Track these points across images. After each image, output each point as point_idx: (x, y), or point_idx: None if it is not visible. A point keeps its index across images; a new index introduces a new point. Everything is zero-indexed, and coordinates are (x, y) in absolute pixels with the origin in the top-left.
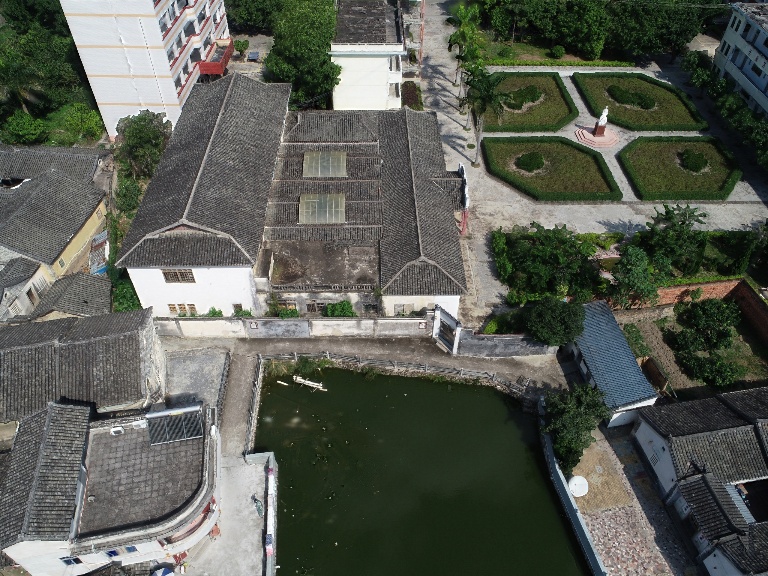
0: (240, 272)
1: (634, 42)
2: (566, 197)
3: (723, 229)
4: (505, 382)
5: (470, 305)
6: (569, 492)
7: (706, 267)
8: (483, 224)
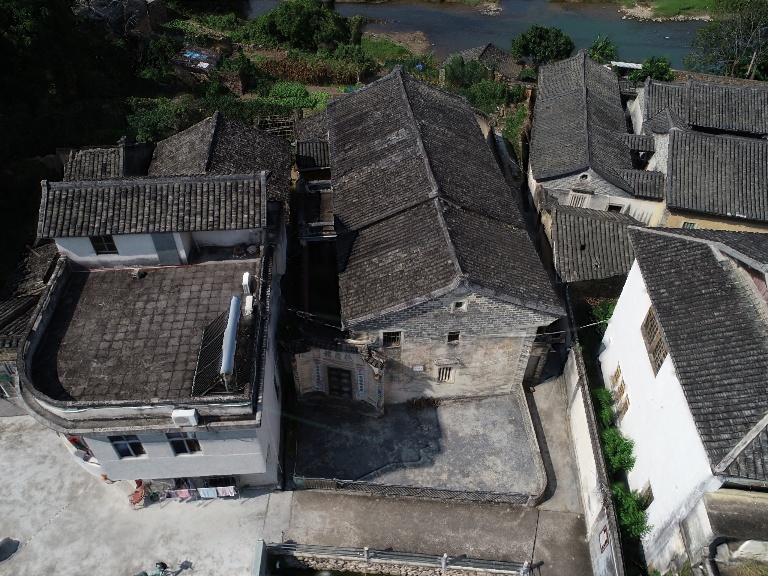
0: (701, 454)
1: None
2: None
3: None
4: None
5: None
6: None
7: None
8: None
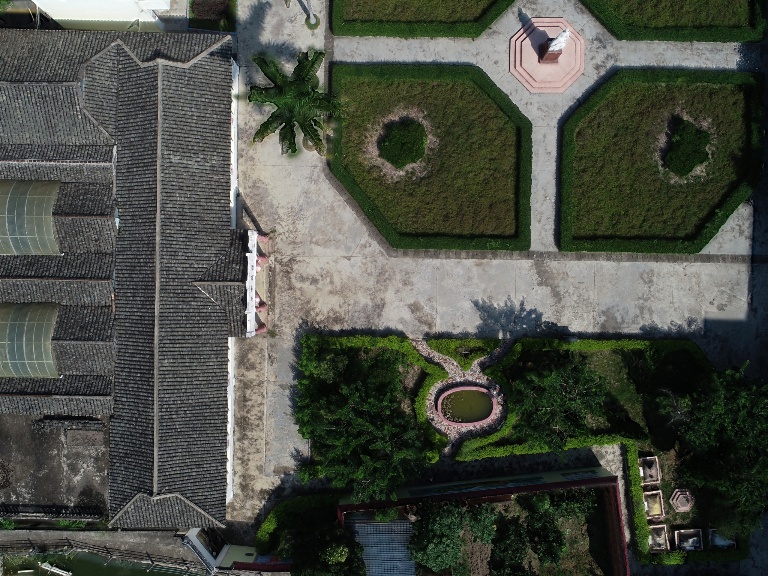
0: None
1: None
2: (437, 249)
3: (657, 325)
4: None
5: (254, 470)
6: None
7: None
8: (297, 303)
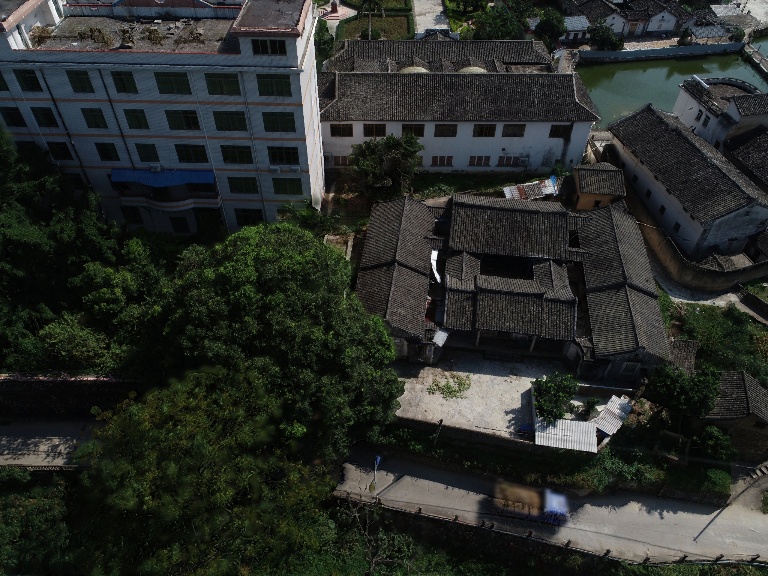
0: None
1: None
2: None
3: None
4: None
5: None
6: (632, 50)
7: (471, 6)
8: None
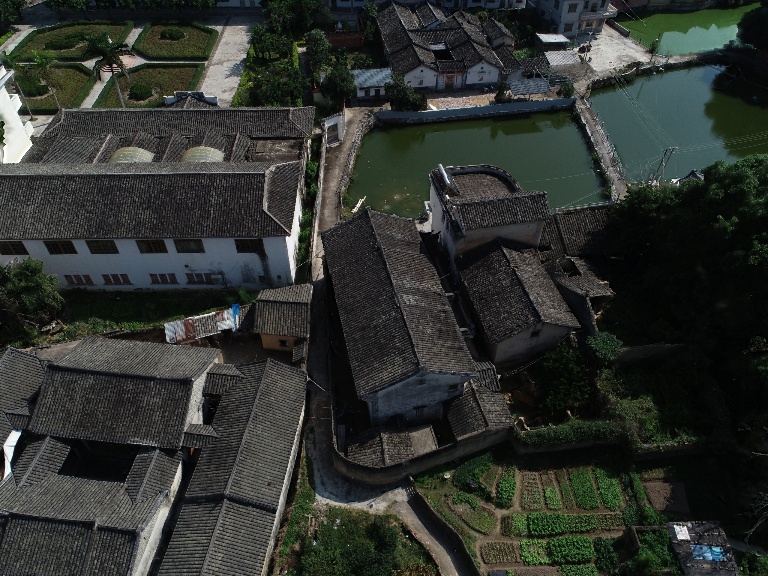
0: None
1: (2, 12)
2: (196, 83)
3: None
4: (366, 124)
5: None
6: (438, 110)
7: None
8: None
